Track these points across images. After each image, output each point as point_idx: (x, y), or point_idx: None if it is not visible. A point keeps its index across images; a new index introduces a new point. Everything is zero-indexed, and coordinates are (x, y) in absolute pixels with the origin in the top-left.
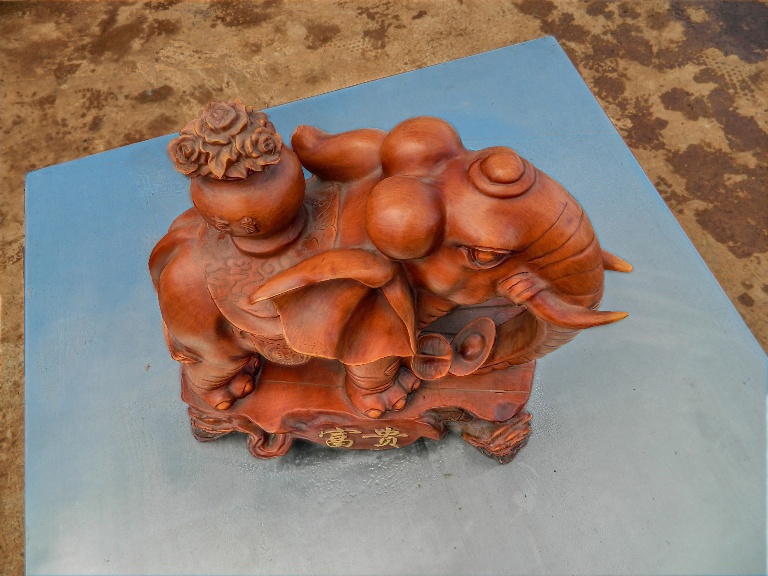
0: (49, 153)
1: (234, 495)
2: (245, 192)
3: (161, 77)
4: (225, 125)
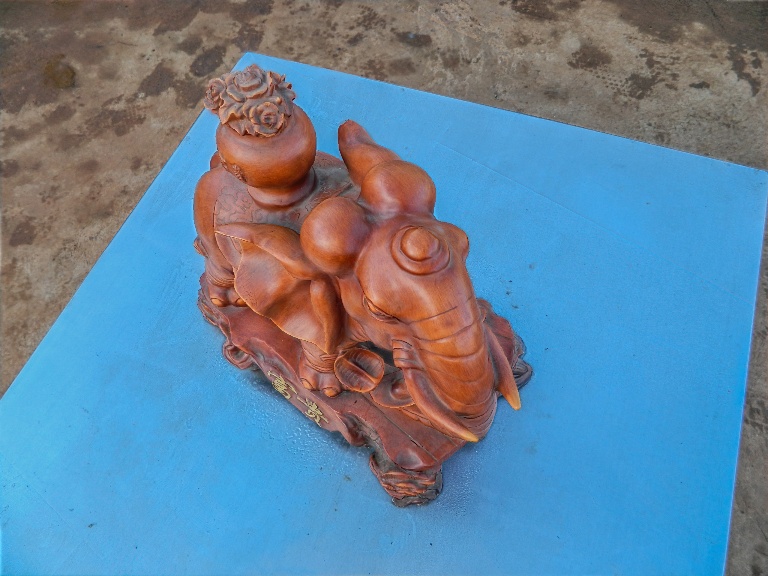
0: (309, 45)
1: (198, 373)
2: (244, 146)
3: (430, 27)
4: (245, 87)
